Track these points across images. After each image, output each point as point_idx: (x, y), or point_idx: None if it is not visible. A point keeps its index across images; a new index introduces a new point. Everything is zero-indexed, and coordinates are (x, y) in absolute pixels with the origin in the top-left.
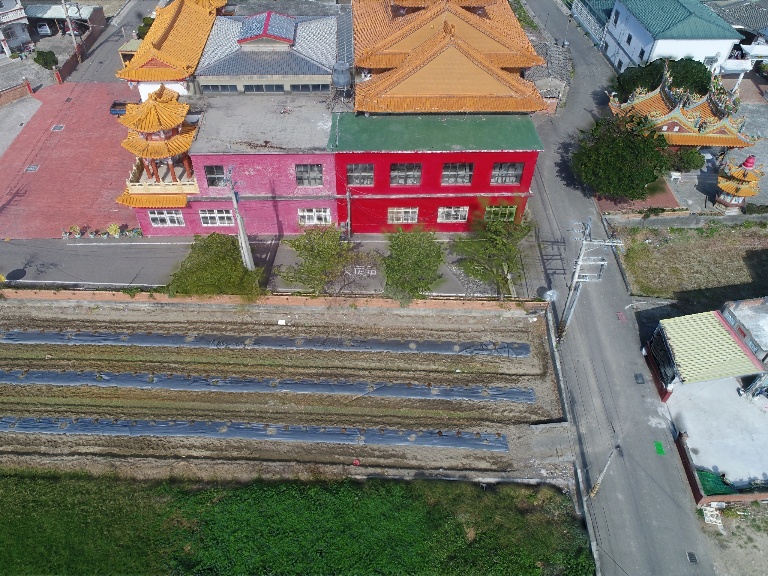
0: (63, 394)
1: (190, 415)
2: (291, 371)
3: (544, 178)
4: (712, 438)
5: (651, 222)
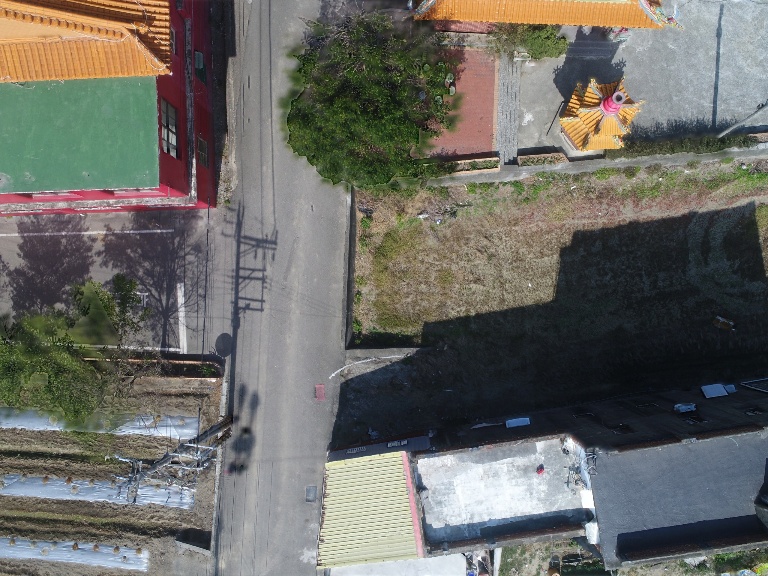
0: None
1: None
2: None
3: (275, 78)
4: (369, 575)
5: (436, 181)
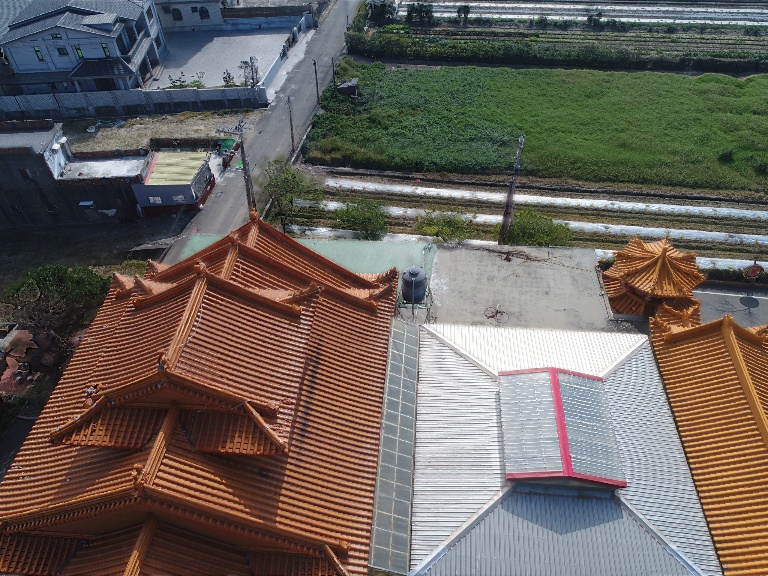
0: (627, 221)
1: (529, 205)
2: (463, 226)
3: None
4: None
5: None
